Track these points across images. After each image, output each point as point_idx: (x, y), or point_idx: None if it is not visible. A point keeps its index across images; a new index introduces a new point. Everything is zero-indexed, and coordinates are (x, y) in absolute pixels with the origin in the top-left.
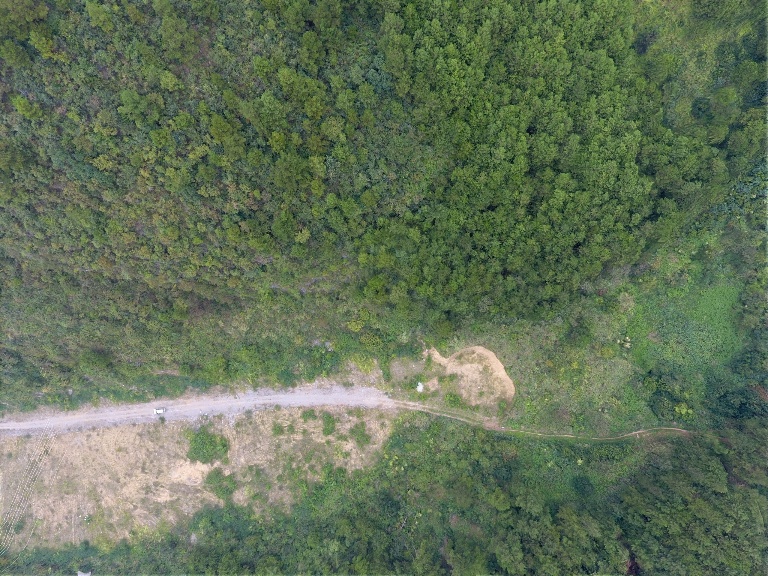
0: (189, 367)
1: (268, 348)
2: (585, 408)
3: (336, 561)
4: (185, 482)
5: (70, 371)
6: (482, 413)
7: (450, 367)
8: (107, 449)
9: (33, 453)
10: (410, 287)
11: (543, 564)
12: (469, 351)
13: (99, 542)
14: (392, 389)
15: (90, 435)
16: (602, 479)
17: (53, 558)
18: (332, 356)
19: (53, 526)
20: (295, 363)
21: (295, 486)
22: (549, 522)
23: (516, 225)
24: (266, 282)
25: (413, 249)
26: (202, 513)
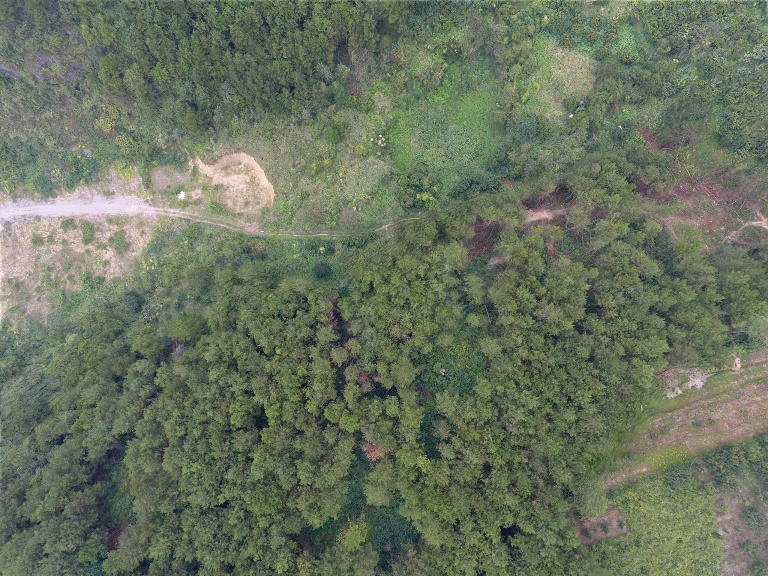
0: None
1: (19, 151)
2: (340, 207)
3: None
4: None
5: None
6: (244, 220)
7: (216, 178)
8: None
9: None
10: (145, 71)
11: (243, 316)
12: (236, 162)
13: None
14: (152, 196)
15: None
16: (343, 265)
17: None
18: (89, 162)
19: None
20: (50, 168)
21: (52, 296)
22: (264, 287)
23: None
24: None
25: (130, 17)
26: None
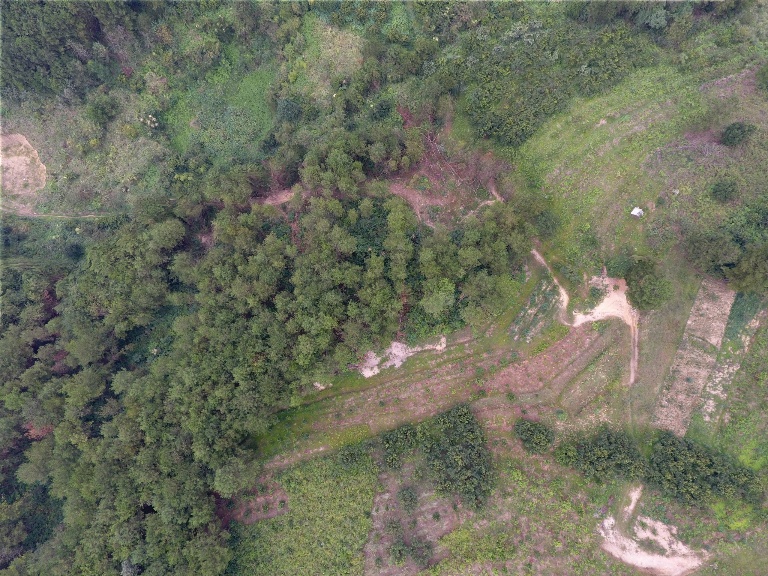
0: None
1: None
2: (110, 188)
3: None
4: None
5: None
6: None
7: None
8: None
9: None
10: None
11: None
12: (16, 143)
13: None
14: None
15: None
16: None
17: None
18: None
19: None
20: None
21: None
22: None
23: None
24: None
25: None
26: None
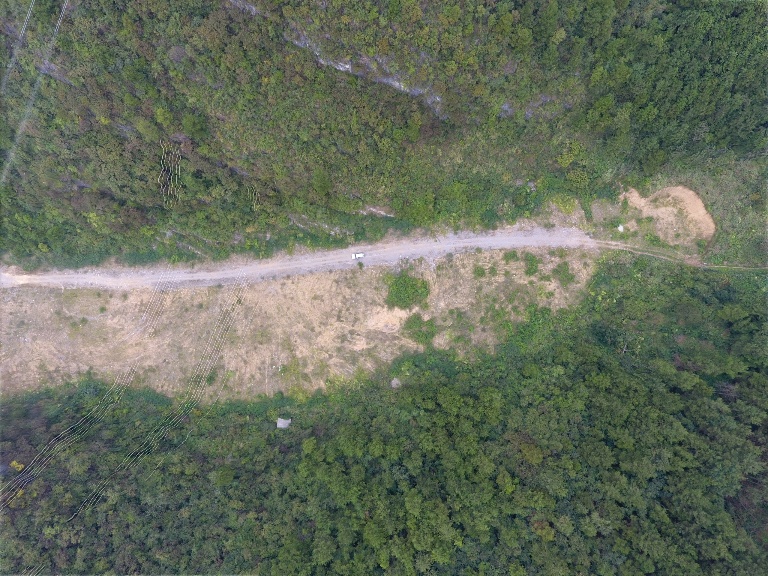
0: (402, 200)
1: (476, 185)
2: None
3: (566, 382)
4: (382, 329)
5: (281, 205)
6: (682, 252)
7: (646, 210)
8: (302, 297)
9: (225, 303)
10: (634, 110)
11: None
12: (664, 194)
13: (294, 392)
14: (594, 229)
15: (285, 283)
16: None
17: (248, 409)
18: (536, 195)
19: (245, 378)
20: (500, 202)
21: (499, 327)
22: None
23: (754, 35)
24: (502, 97)
25: (652, 60)
26: (402, 358)
